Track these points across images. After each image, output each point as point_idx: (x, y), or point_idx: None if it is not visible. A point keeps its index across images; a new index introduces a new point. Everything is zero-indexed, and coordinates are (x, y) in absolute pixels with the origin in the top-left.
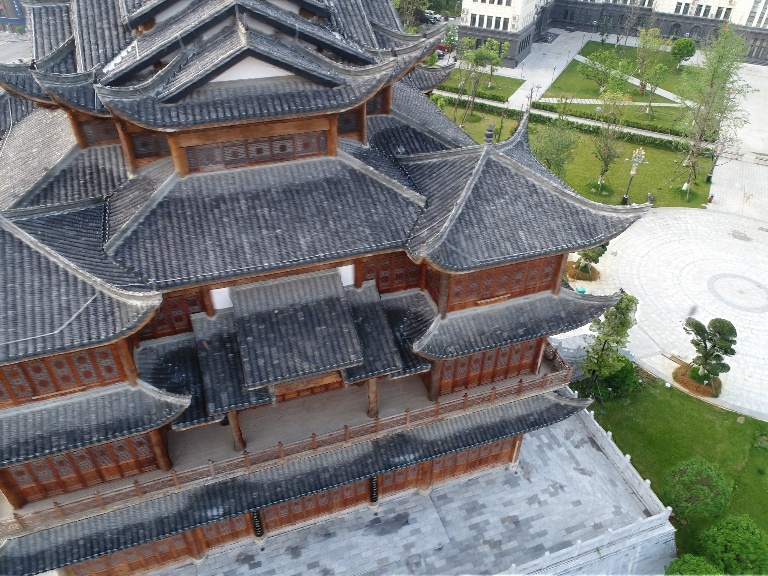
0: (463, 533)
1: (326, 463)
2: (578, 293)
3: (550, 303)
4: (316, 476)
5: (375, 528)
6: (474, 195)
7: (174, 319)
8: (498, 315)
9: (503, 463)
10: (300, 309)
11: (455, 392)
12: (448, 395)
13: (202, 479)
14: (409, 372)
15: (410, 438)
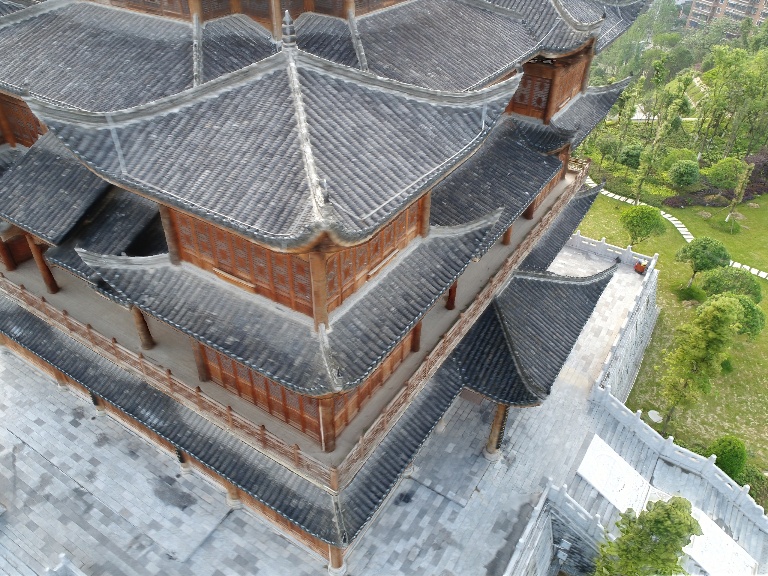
0: (204, 569)
1: (102, 362)
2: (325, 344)
3: (301, 336)
4: (86, 366)
5: (161, 484)
6: (214, 103)
7: (31, 132)
8: (230, 303)
9: (323, 555)
10: (71, 166)
11: (228, 390)
12: (219, 387)
13: (3, 289)
14: (108, 296)
15: (173, 404)
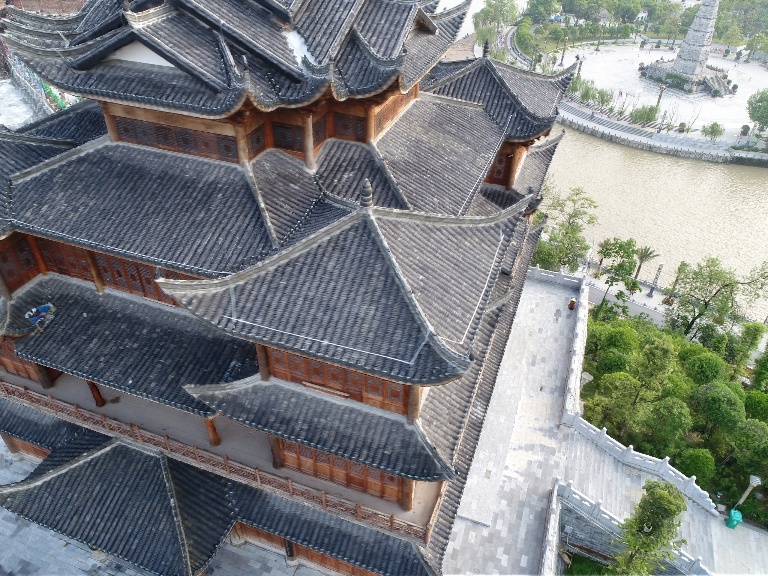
0: None
1: None
2: None
3: None
4: None
5: None
6: None
7: None
8: None
9: None
10: None
11: None
12: None
13: None
14: None
15: None
